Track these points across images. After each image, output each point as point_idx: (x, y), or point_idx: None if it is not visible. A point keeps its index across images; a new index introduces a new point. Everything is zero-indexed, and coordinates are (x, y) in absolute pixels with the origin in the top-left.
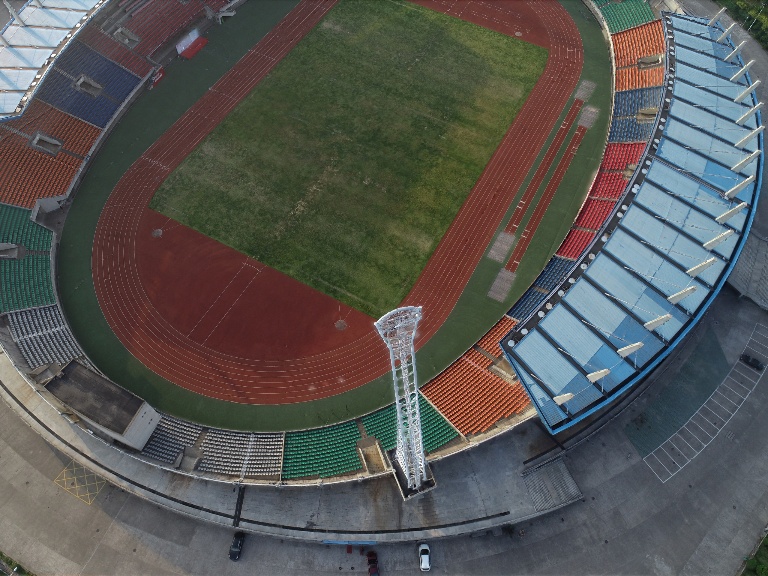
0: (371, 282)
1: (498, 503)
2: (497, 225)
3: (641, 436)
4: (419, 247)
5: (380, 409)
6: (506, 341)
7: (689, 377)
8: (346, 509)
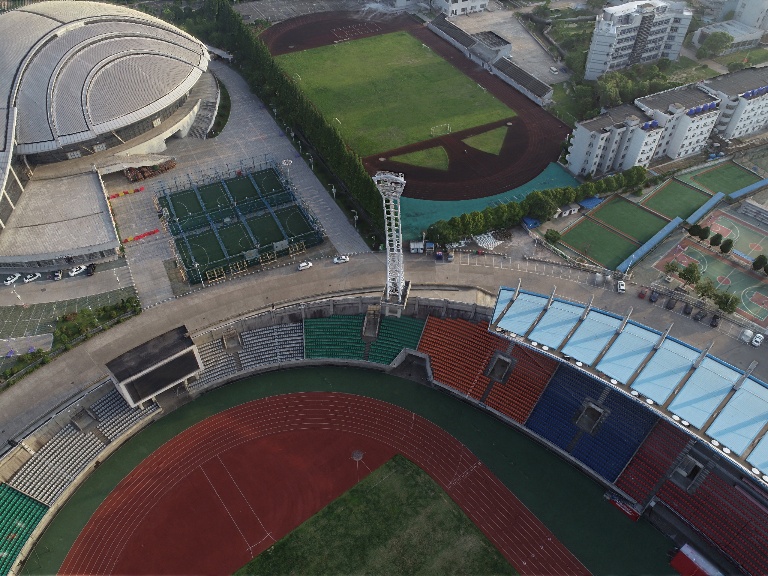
0: None
1: None
2: None
3: None
4: None
5: None
6: None
7: None
8: None
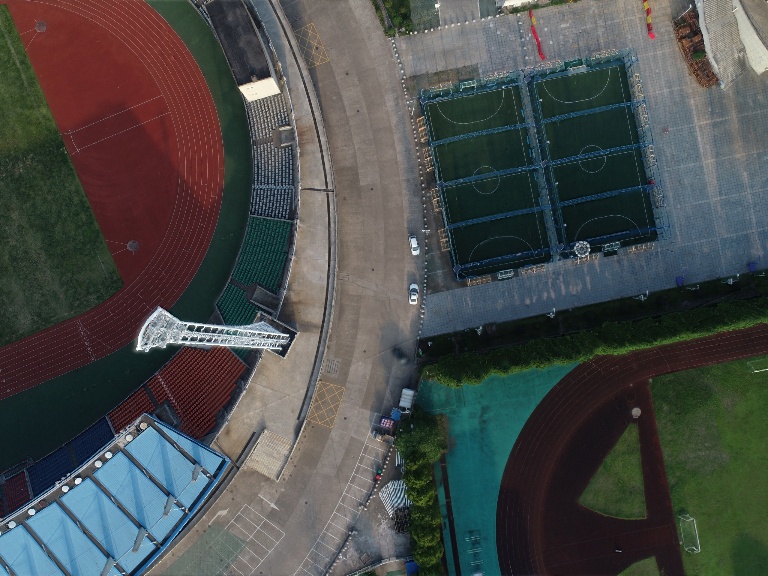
0: None
1: None
2: None
3: None
4: None
5: None
6: None
7: None
8: None
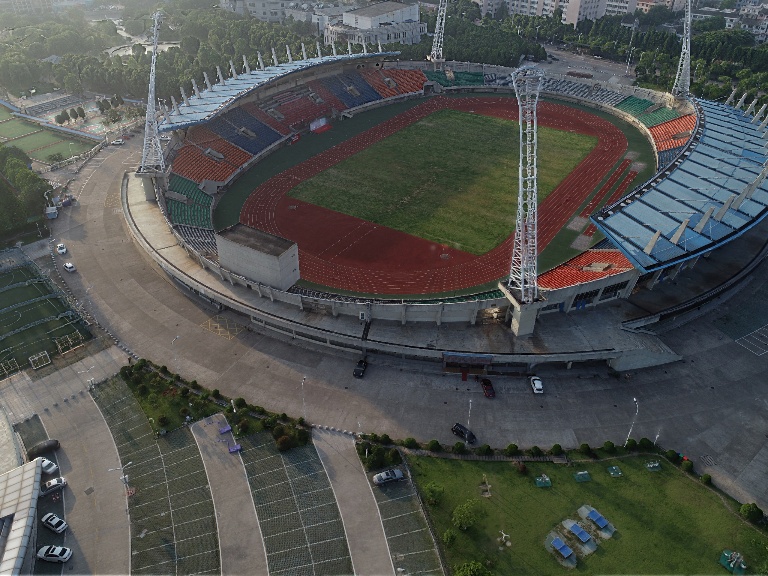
0: (469, 236)
1: (602, 343)
2: (572, 213)
3: (729, 328)
4: (507, 221)
5: (486, 292)
6: (596, 217)
7: (765, 297)
8: (462, 339)
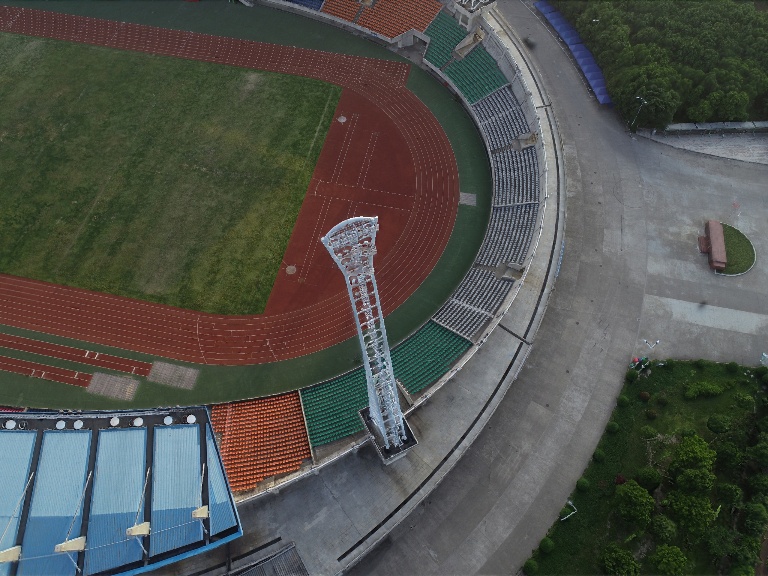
0: None
1: None
2: None
3: None
4: None
5: None
6: None
7: None
8: None
